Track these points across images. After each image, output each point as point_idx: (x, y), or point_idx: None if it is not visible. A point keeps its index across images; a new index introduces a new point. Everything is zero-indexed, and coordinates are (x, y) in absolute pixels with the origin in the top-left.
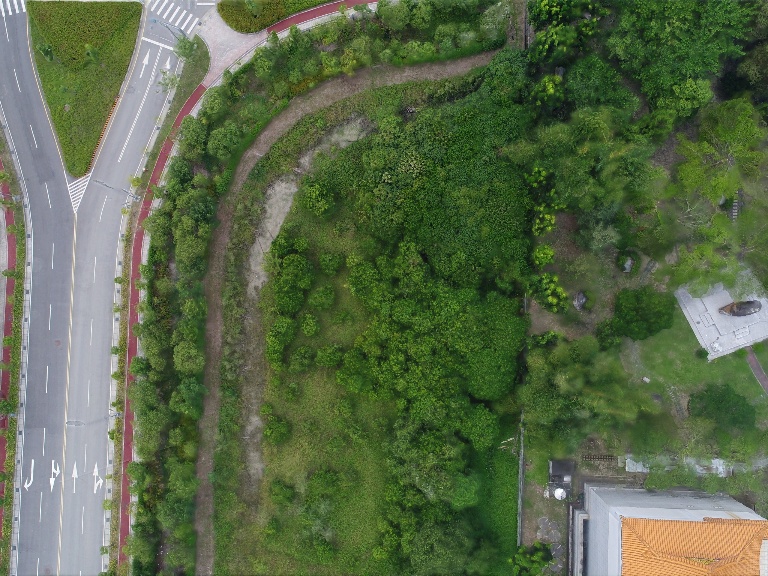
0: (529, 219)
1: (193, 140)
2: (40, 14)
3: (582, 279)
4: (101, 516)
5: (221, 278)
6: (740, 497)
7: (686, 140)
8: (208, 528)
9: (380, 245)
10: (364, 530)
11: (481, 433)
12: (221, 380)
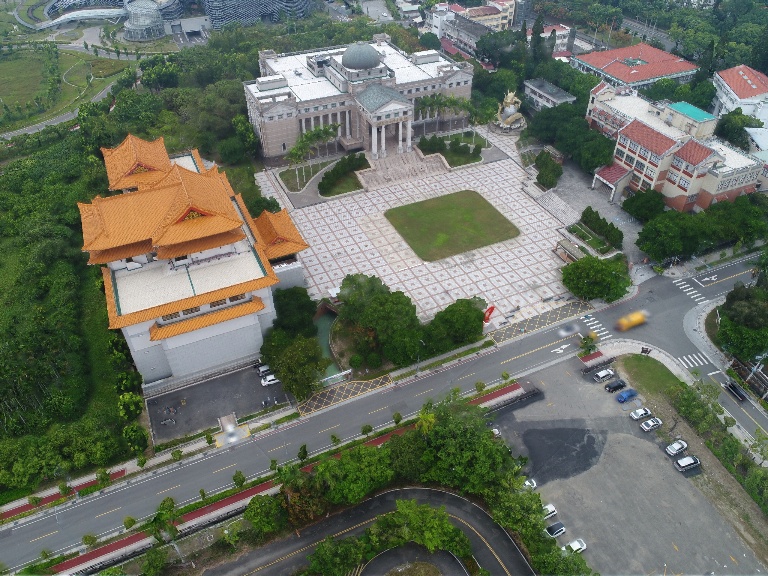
0: None
1: None
2: None
3: None
4: None
5: None
6: None
7: None
8: None
9: None
10: (8, 280)
11: None
12: None
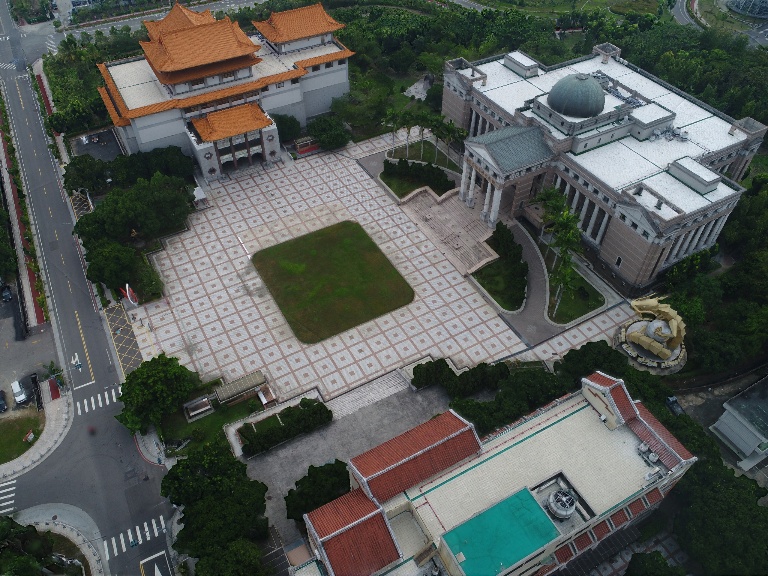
0: None
1: None
2: None
3: None
4: None
5: None
6: None
7: (473, 45)
8: None
9: None
10: None
11: None
12: None
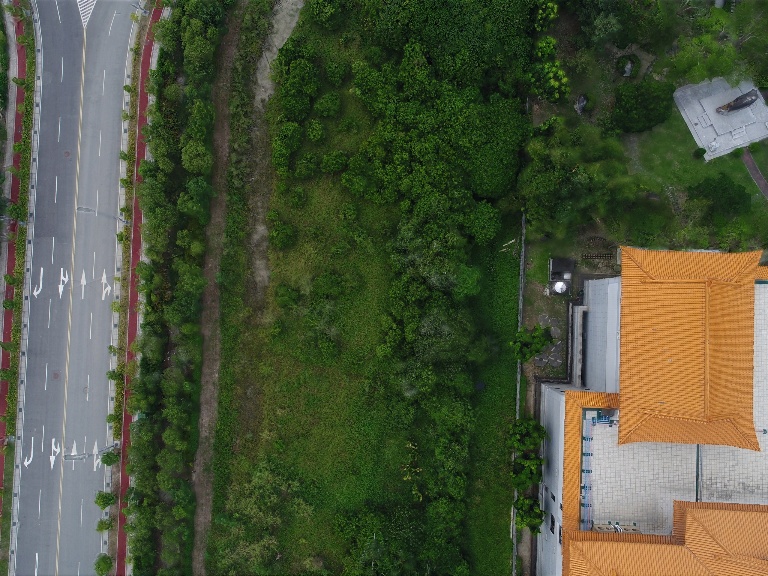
0: (532, 20)
1: None
2: None
3: (583, 75)
4: (109, 322)
5: (228, 90)
6: None
7: None
8: (214, 332)
9: (385, 54)
10: (368, 332)
11: (483, 226)
12: (228, 188)
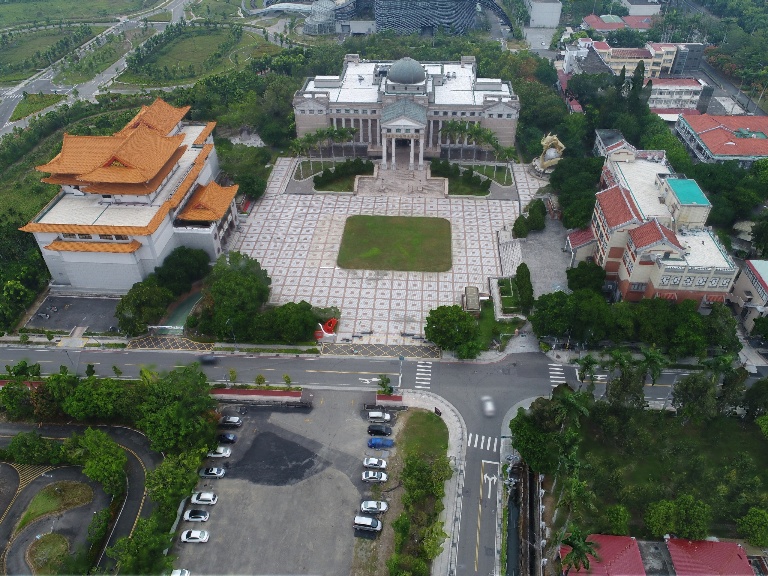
0: None
1: (63, 108)
2: (29, 95)
3: None
4: None
5: None
6: (219, 160)
7: None
8: None
9: None
10: None
11: None
12: None
